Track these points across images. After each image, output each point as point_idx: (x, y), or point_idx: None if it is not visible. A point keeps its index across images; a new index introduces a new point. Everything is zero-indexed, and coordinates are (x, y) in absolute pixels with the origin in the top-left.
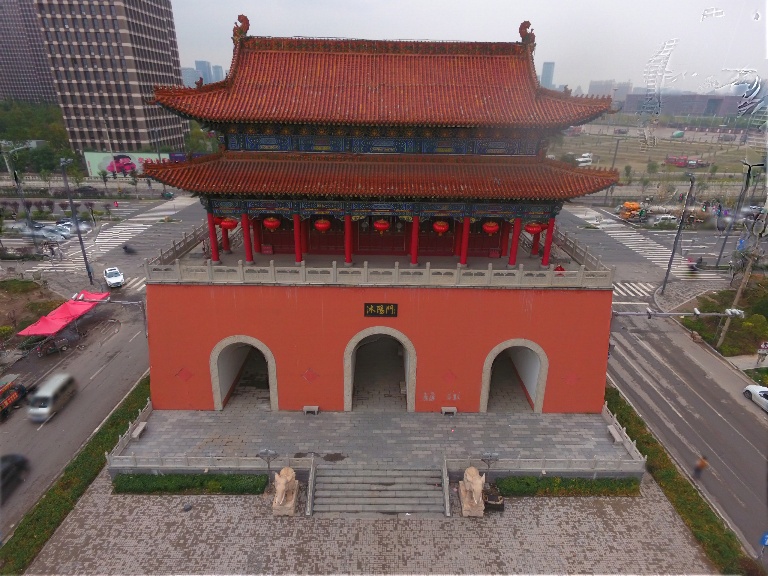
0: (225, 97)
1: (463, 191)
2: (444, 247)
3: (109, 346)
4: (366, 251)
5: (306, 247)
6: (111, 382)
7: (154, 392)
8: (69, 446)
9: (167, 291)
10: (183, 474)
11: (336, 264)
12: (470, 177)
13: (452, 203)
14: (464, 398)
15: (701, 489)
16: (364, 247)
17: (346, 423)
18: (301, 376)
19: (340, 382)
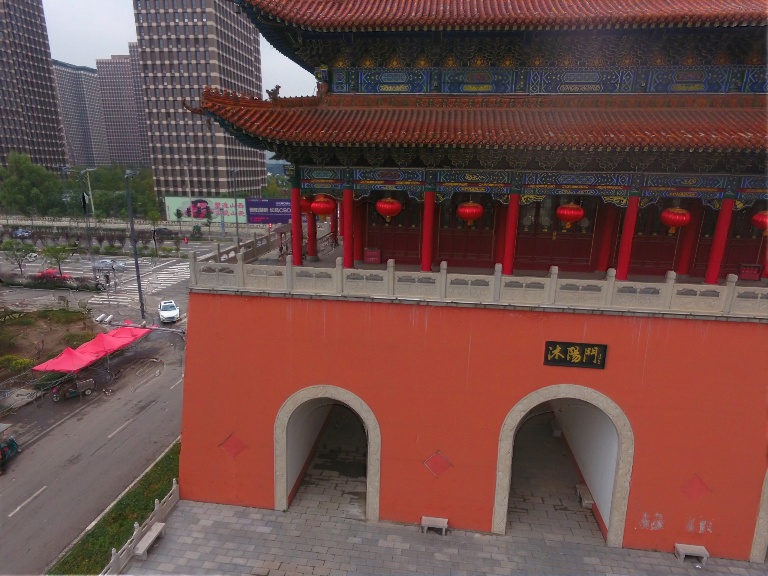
0: (336, 6)
1: (752, 138)
2: (658, 260)
3: (144, 393)
4: (526, 263)
5: (432, 254)
6: (133, 445)
7: (184, 470)
8: (43, 552)
9: (220, 305)
10: None
11: None
12: (747, 124)
13: (704, 173)
14: (720, 531)
15: None
16: (523, 257)
17: (501, 560)
18: (422, 463)
19: (489, 480)
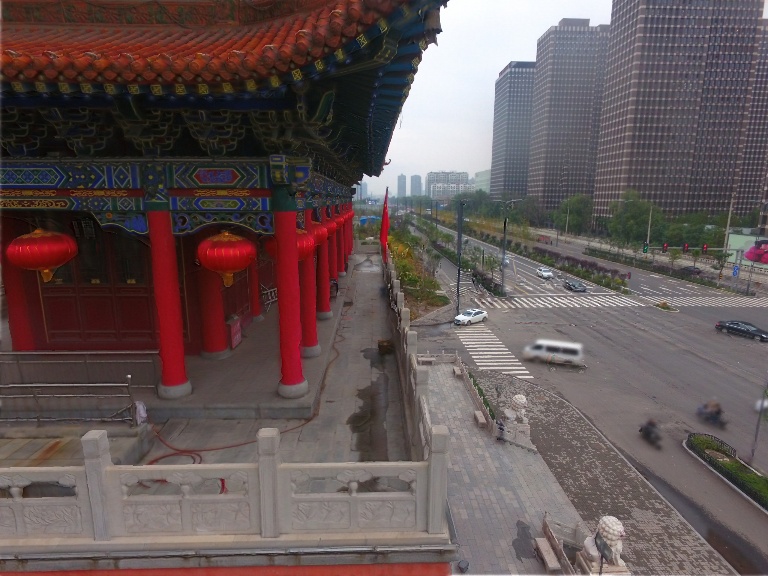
0: None
1: None
2: None
3: None
4: None
5: None
6: None
7: None
8: None
9: None
10: None
11: None
12: None
13: None
14: None
15: None
16: None
17: None
18: None
19: None
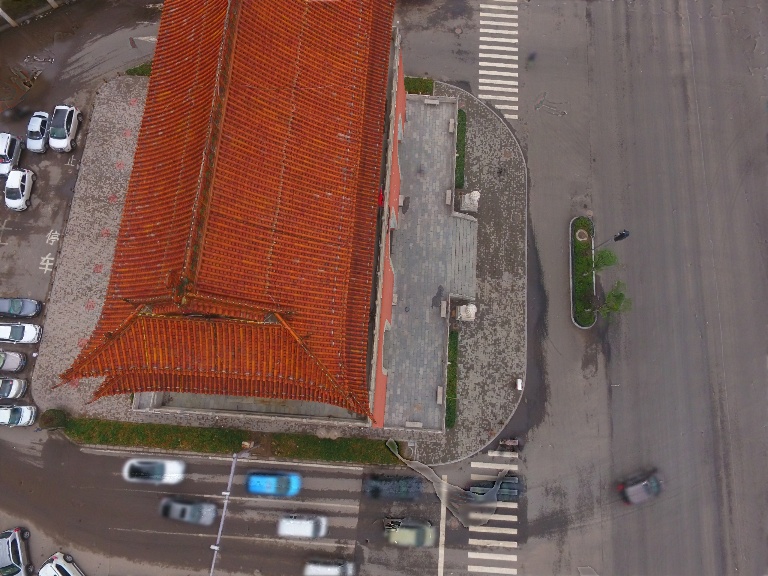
0: None
1: None
2: None
3: None
4: None
5: None
6: None
7: None
8: None
9: None
10: None
11: None
12: None
13: None
14: None
15: (131, 453)
16: None
17: None
18: None
19: None
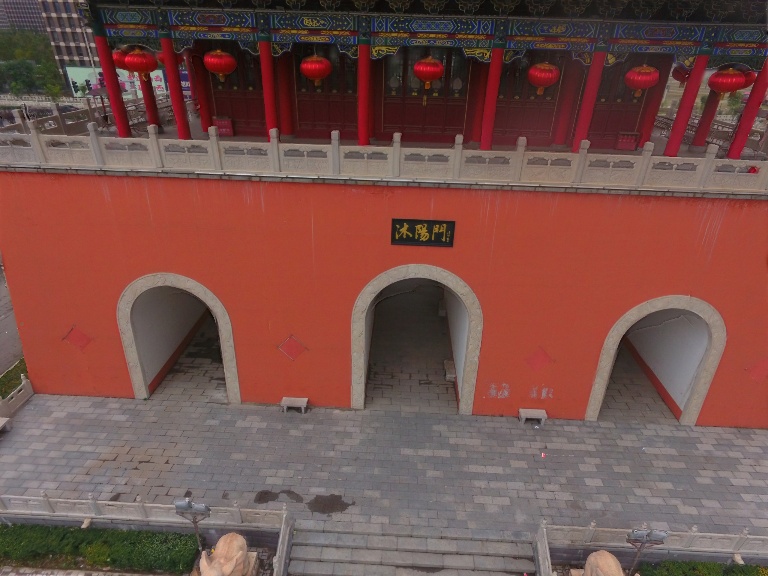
0: None
1: None
2: (535, 128)
3: None
4: None
5: (290, 123)
6: (2, 342)
7: (32, 365)
8: None
9: (23, 185)
10: (47, 525)
11: (338, 137)
12: None
13: (574, 19)
14: (560, 396)
15: None
16: (392, 126)
17: (353, 432)
18: (277, 348)
19: (345, 361)
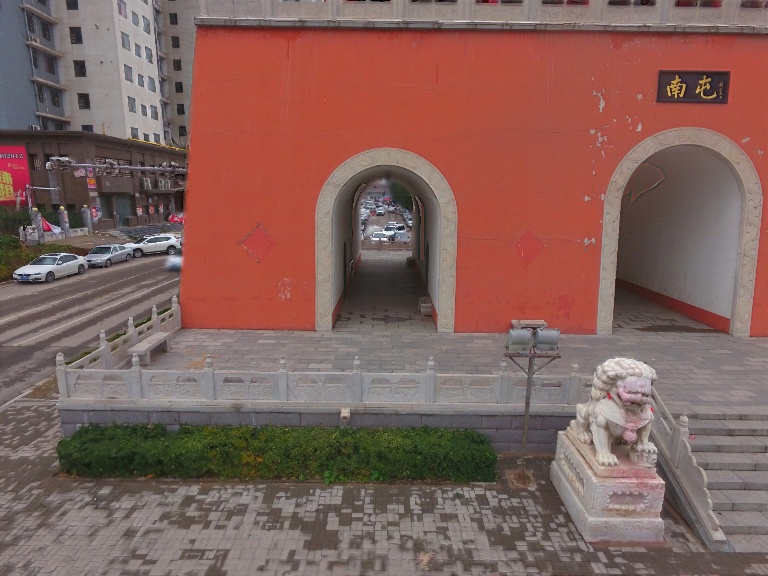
0: None
1: None
2: None
3: None
4: None
5: None
6: None
7: None
8: None
9: None
10: None
11: None
12: None
13: None
14: None
15: None
16: None
17: None
18: None
19: None
